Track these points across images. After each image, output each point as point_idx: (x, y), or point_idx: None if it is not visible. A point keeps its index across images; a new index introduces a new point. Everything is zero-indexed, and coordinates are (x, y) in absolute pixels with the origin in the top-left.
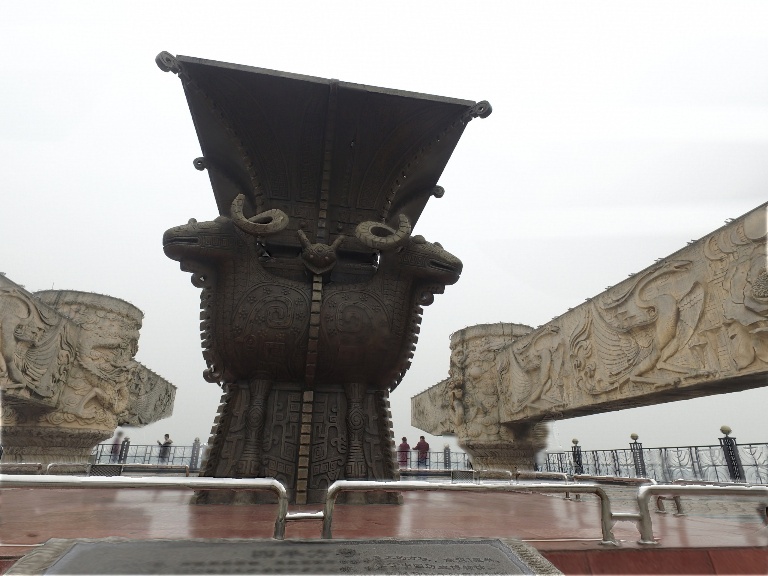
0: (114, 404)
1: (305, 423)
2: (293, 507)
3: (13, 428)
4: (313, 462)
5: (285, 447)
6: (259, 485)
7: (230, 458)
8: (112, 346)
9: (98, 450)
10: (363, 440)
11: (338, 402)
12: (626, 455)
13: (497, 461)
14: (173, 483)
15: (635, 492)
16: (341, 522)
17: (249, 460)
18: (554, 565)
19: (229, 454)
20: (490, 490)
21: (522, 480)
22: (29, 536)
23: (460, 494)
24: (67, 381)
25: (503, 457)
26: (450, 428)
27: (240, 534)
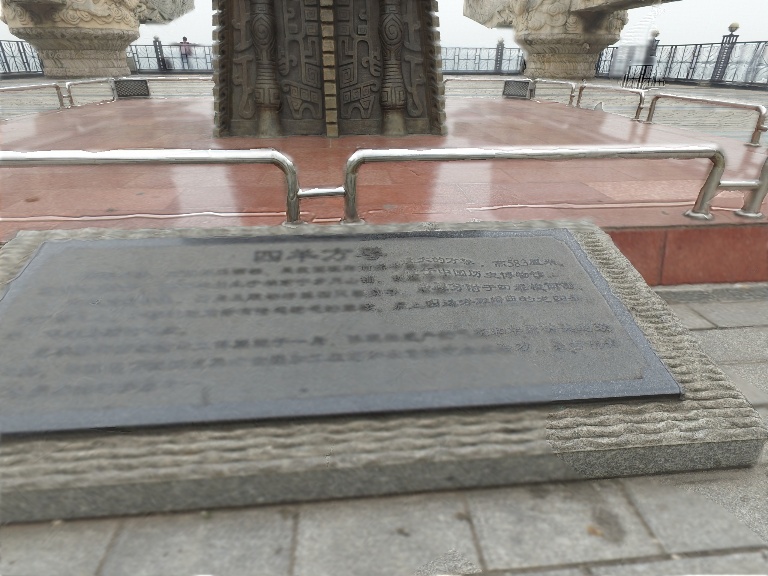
0: None
1: (326, 38)
2: (324, 141)
3: (33, 30)
4: (342, 88)
5: (306, 70)
6: (256, 158)
7: (244, 85)
8: None
9: (133, 51)
10: (401, 58)
11: (367, 4)
12: (711, 50)
13: (555, 59)
14: (144, 158)
15: (705, 96)
16: (374, 170)
17: (266, 87)
18: (622, 242)
19: (241, 80)
20: (565, 158)
21: (578, 80)
22: (26, 201)
23: (511, 112)
24: None
25: (563, 54)
26: (508, 18)
27: (257, 194)
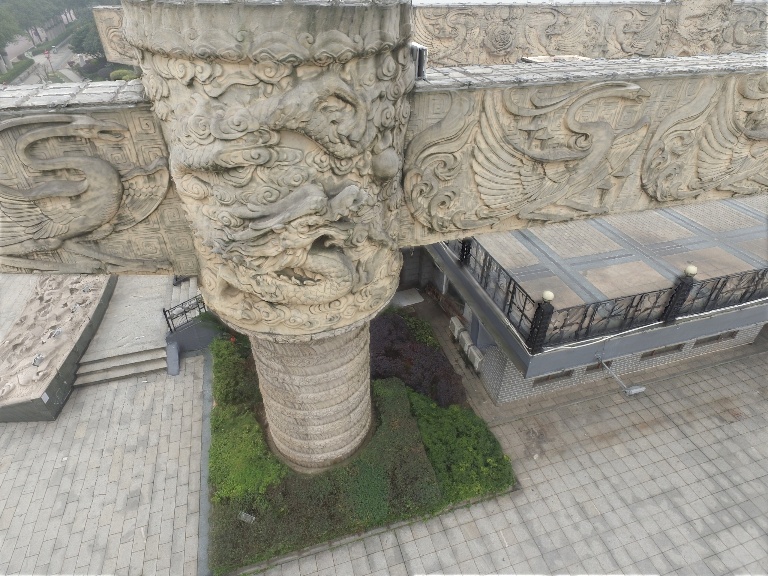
0: None
1: None
2: None
3: None
4: None
5: None
6: None
7: None
8: (699, 15)
9: None
10: None
11: None
12: None
13: None
14: None
15: None
16: None
17: None
18: None
19: None
20: None
21: None
22: None
23: None
24: (669, 42)
25: None
26: None
27: None
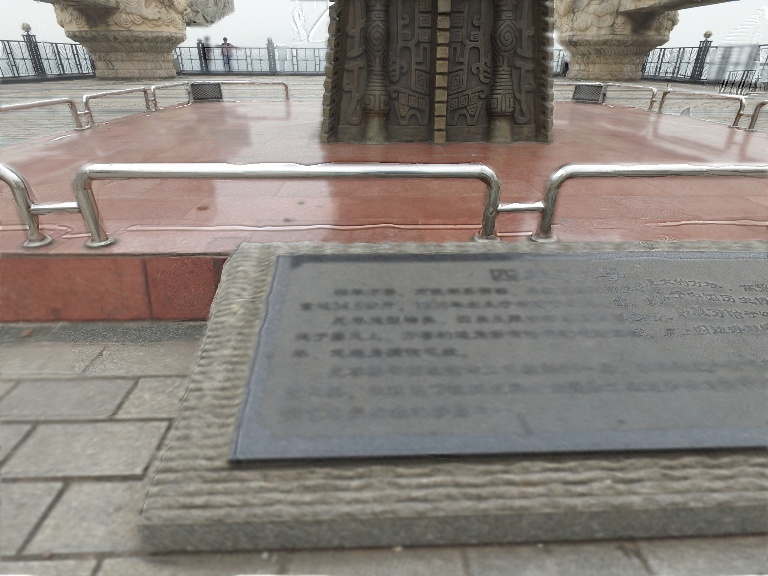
0: (174, 1)
1: (441, 44)
2: (434, 149)
3: (88, 33)
4: (450, 94)
5: (416, 76)
6: (464, 173)
7: (353, 91)
8: None
9: (177, 53)
10: (512, 65)
11: (482, 11)
12: None
13: (600, 60)
14: (356, 172)
15: None
16: (512, 180)
17: (377, 94)
18: None
19: (352, 86)
20: None
21: (624, 82)
22: (199, 209)
23: (595, 118)
24: None
25: (609, 55)
26: None
27: (416, 205)
